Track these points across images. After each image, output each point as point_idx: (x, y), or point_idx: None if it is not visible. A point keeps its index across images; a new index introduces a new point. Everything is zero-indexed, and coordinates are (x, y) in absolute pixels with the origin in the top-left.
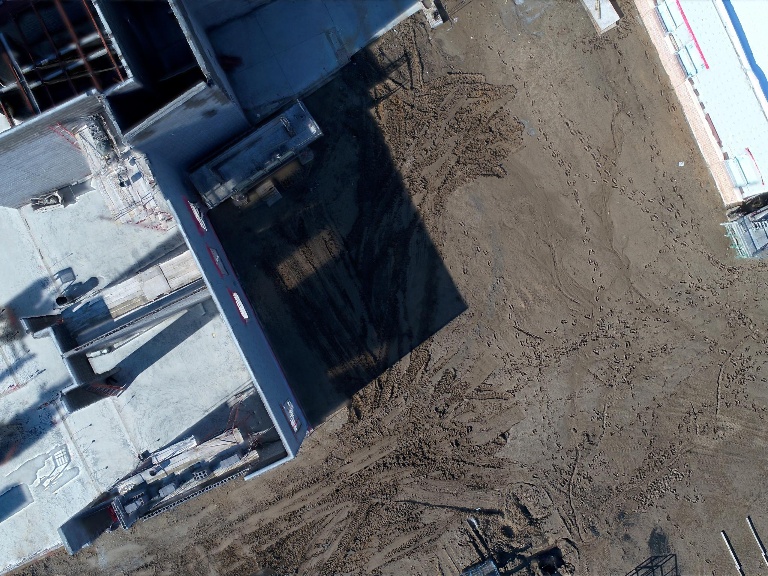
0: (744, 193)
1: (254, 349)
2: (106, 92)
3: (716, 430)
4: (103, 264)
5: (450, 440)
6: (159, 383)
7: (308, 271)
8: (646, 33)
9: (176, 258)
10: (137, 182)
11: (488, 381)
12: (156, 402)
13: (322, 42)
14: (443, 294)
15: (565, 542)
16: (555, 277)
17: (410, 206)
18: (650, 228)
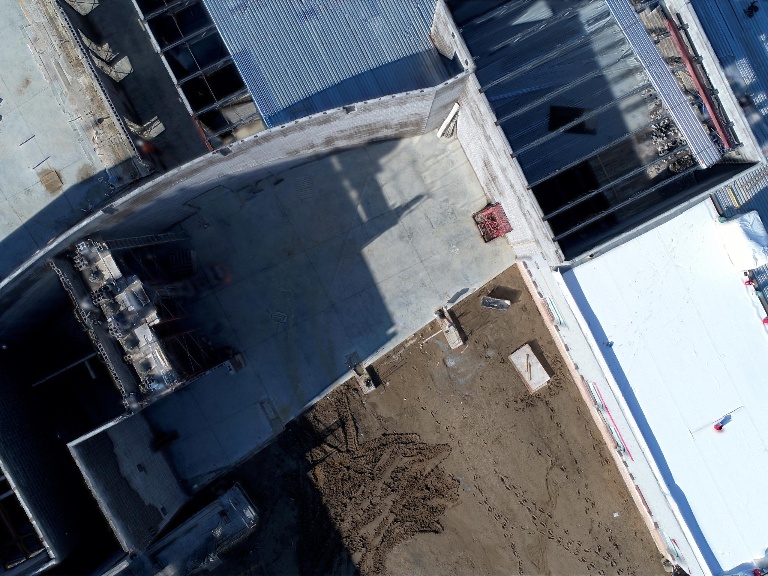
0: (675, 560)
1: None
2: (29, 574)
3: None
4: None
5: None
6: None
7: None
8: (577, 390)
9: None
10: None
11: None
12: None
13: (256, 412)
14: None
15: None
16: None
17: (349, 565)
18: None
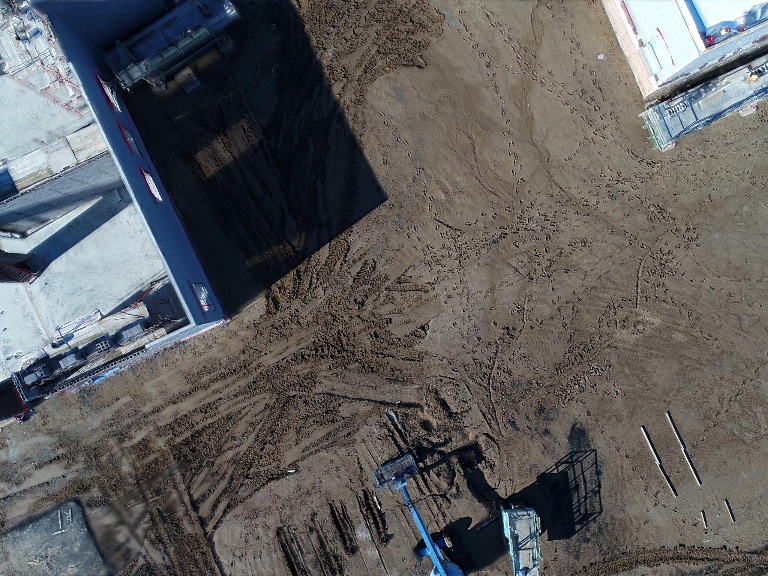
0: (659, 80)
1: (162, 224)
2: None
3: (636, 325)
4: (17, 149)
5: (369, 332)
6: (73, 270)
7: (226, 159)
8: None
9: (83, 130)
10: (34, 37)
11: (408, 273)
12: (70, 290)
13: None
14: (363, 184)
15: (485, 437)
16: (475, 169)
17: (329, 95)
18: (570, 121)
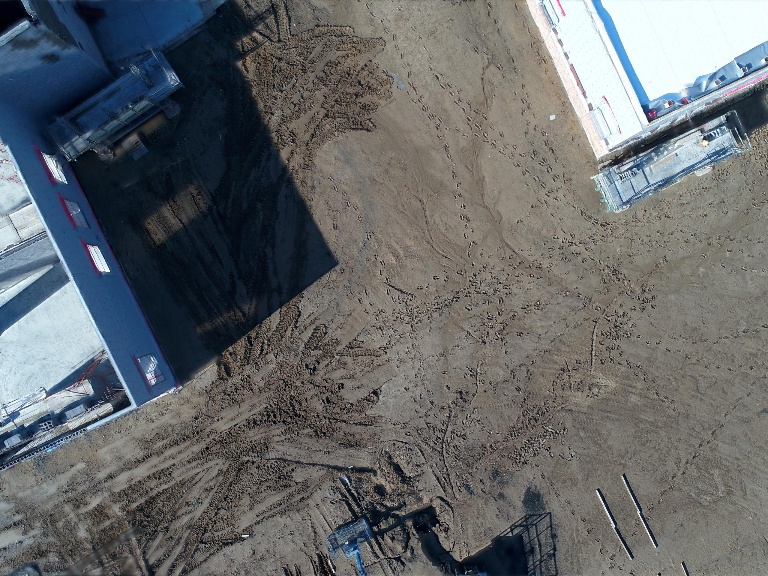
0: (609, 145)
1: (107, 301)
2: None
3: (591, 387)
4: None
5: (321, 397)
6: (25, 339)
7: (176, 226)
8: None
9: (26, 208)
10: None
11: (359, 338)
12: (22, 359)
13: None
14: (313, 250)
15: (439, 500)
16: (426, 233)
17: (278, 160)
18: (522, 183)
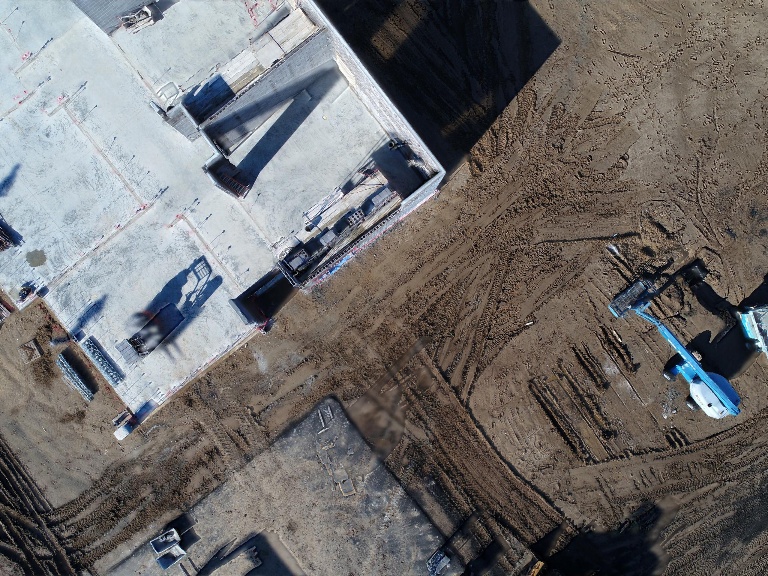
0: None
1: None
2: None
3: None
4: (202, 72)
5: (573, 173)
6: (281, 176)
7: (401, 38)
8: None
9: (283, 21)
10: None
11: (597, 108)
12: (282, 195)
13: None
14: (535, 33)
15: (705, 250)
16: None
17: None
18: None
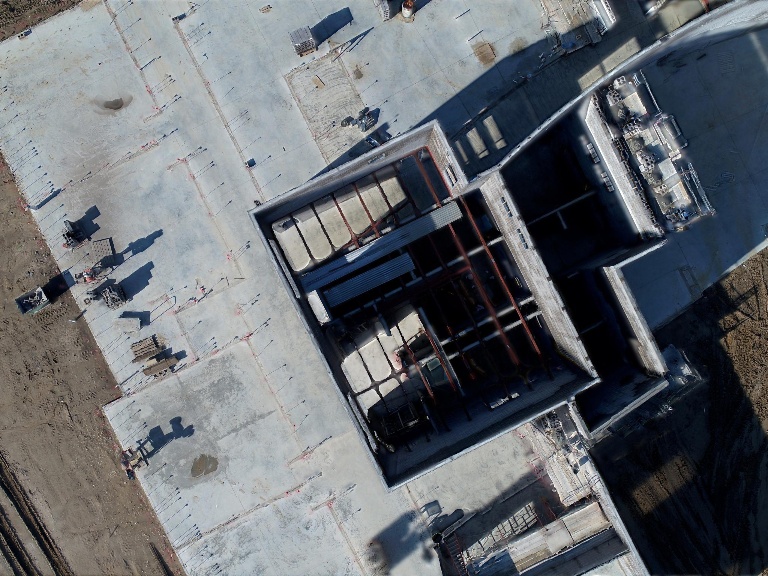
0: None
1: None
2: (574, 392)
3: None
4: (468, 496)
5: None
6: None
7: (662, 496)
8: None
9: (579, 512)
10: (584, 465)
11: None
12: None
13: (676, 278)
14: None
15: None
16: None
17: (760, 432)
18: None
